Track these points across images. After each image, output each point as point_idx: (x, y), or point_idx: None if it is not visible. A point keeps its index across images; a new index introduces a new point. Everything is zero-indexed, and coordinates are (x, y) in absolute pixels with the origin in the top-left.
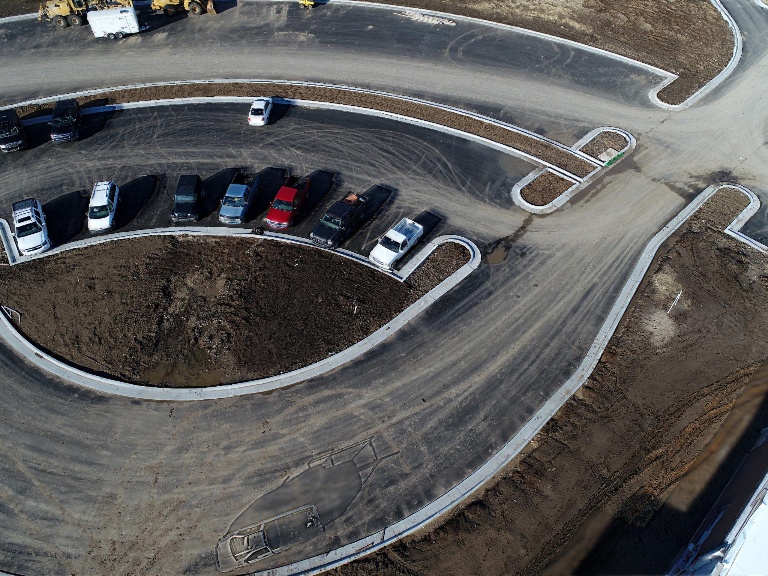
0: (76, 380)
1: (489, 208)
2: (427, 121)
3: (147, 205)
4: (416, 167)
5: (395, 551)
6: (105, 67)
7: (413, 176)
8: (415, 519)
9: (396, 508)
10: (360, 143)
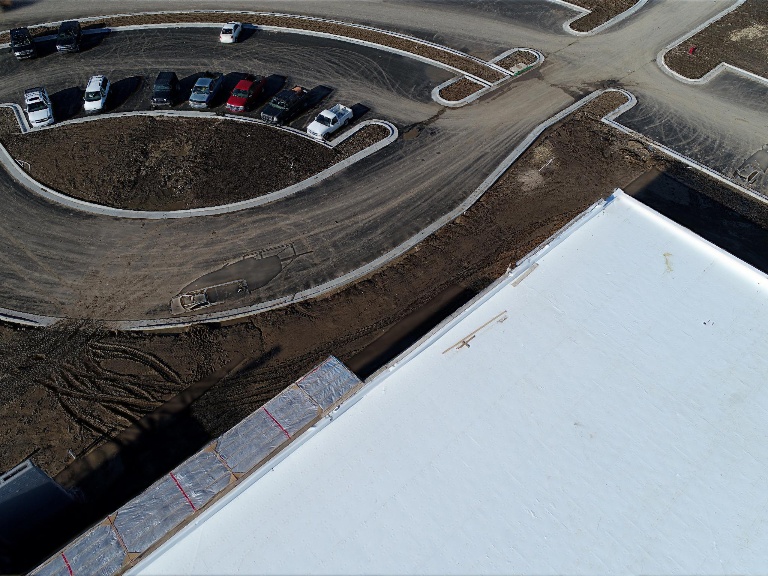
0: (72, 205)
1: (411, 102)
2: (370, 42)
3: (133, 96)
4: (356, 74)
5: (301, 305)
6: (103, 0)
7: (352, 80)
8: (318, 288)
9: (305, 282)
10: (312, 57)
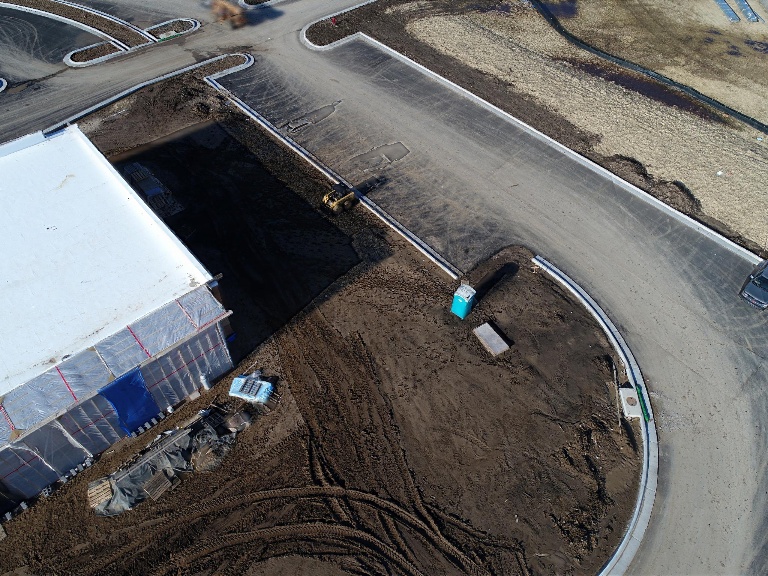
0: None
1: (40, 63)
2: (45, 11)
3: None
4: (8, 38)
5: None
6: None
7: (0, 43)
8: None
9: None
10: None
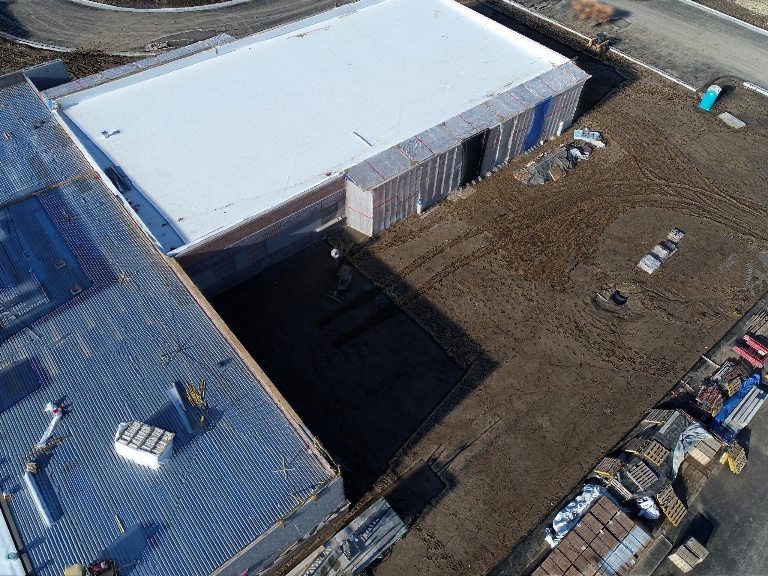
0: (89, 4)
1: None
2: None
3: None
4: None
5: None
6: None
7: None
8: None
9: None
10: None
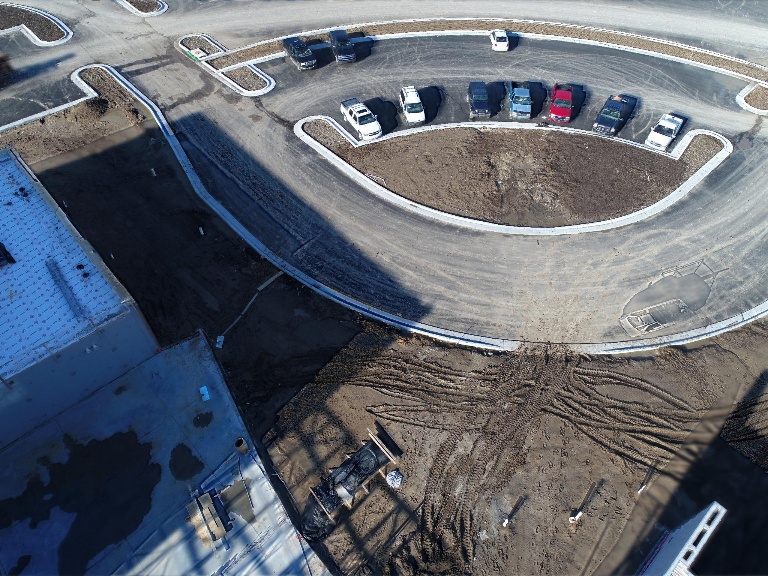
0: (453, 221)
1: (723, 111)
2: (642, 49)
3: (441, 107)
4: (648, 82)
5: (756, 326)
6: (346, 9)
7: (649, 88)
8: (762, 308)
9: (744, 302)
10: (592, 65)
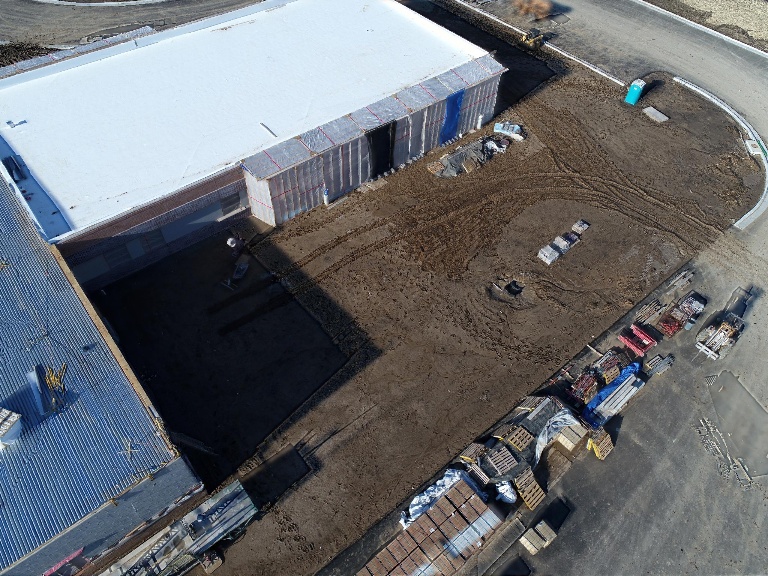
0: None
1: None
2: None
3: None
4: None
5: None
6: None
7: None
8: None
9: None
10: None
